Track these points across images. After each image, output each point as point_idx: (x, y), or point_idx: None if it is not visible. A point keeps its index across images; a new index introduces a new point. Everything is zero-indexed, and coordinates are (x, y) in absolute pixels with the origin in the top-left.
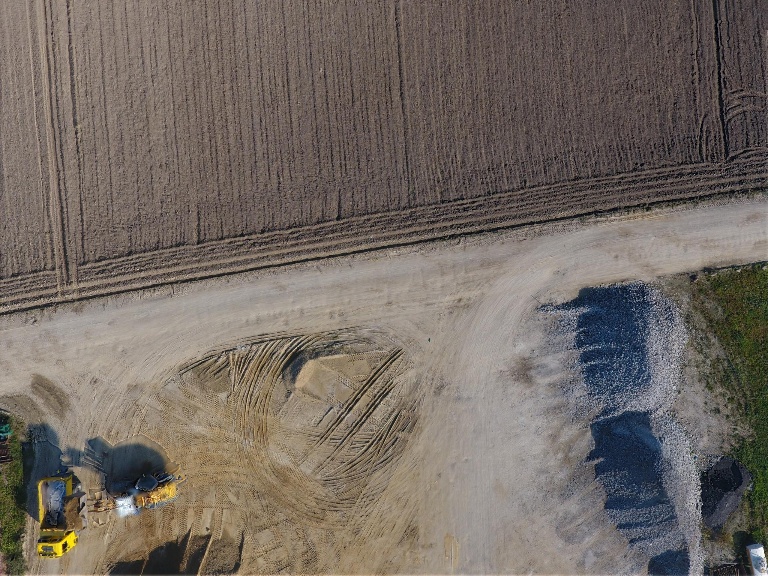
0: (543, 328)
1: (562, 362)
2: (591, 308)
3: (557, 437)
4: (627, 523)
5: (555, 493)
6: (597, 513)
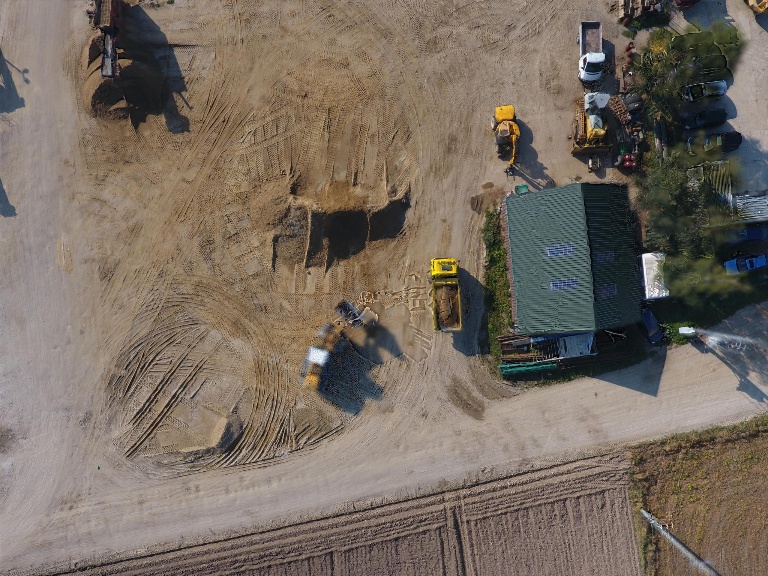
0: None
1: None
2: None
3: None
4: None
5: None
6: None
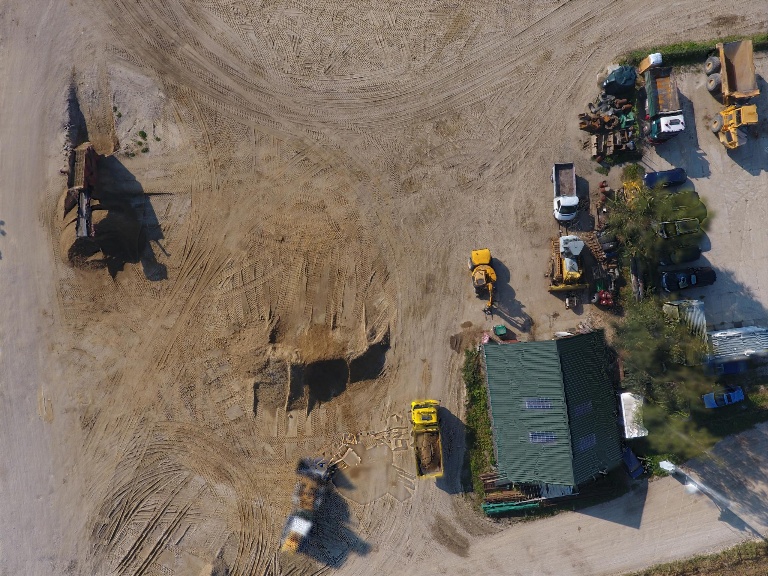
0: None
1: None
2: None
3: None
4: None
5: None
6: None
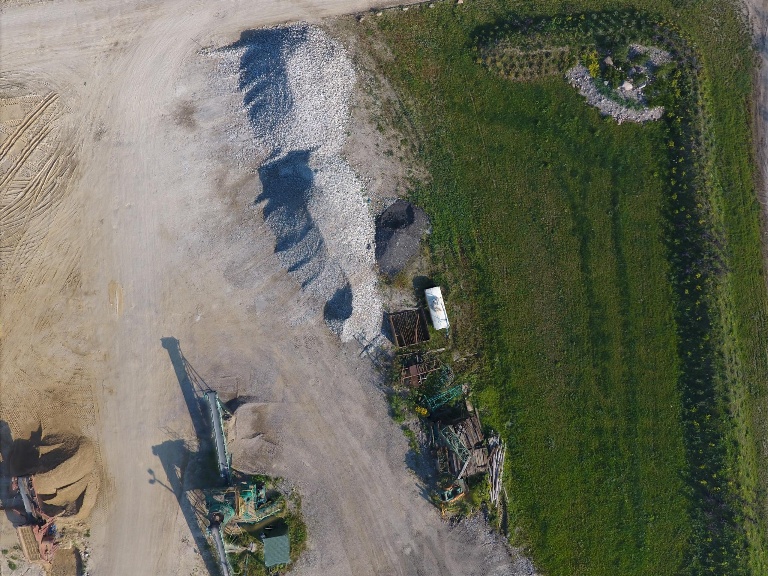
0: (204, 71)
1: (225, 105)
2: (248, 46)
3: (223, 181)
4: (295, 264)
5: (222, 237)
6: (267, 257)
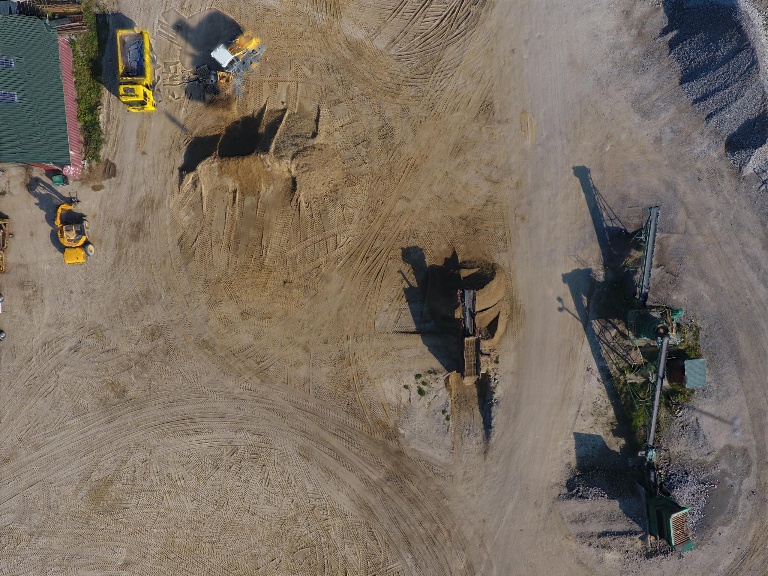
0: None
1: None
2: None
3: (630, 13)
4: (703, 95)
5: (630, 68)
6: (672, 89)
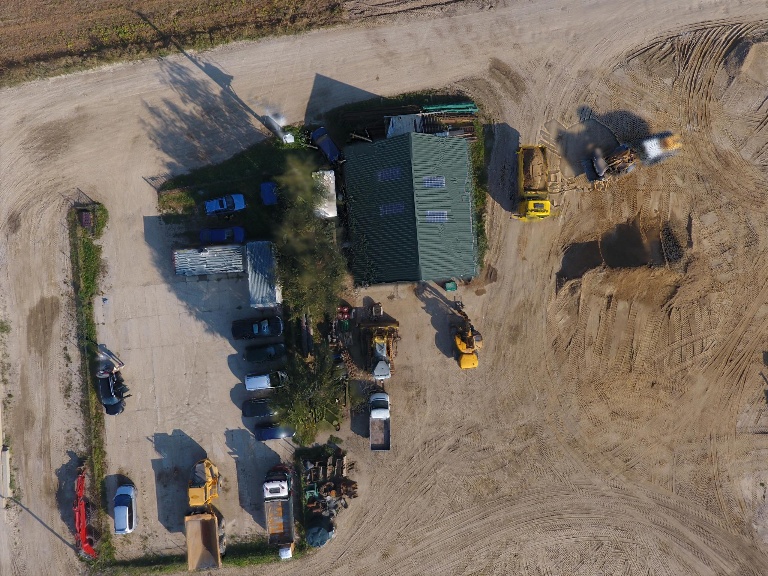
0: None
1: None
2: None
3: None
4: None
5: None
6: None
